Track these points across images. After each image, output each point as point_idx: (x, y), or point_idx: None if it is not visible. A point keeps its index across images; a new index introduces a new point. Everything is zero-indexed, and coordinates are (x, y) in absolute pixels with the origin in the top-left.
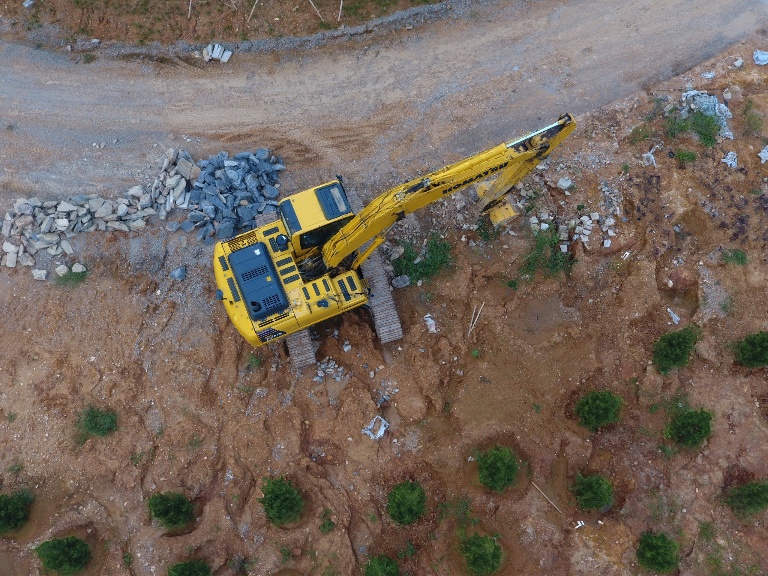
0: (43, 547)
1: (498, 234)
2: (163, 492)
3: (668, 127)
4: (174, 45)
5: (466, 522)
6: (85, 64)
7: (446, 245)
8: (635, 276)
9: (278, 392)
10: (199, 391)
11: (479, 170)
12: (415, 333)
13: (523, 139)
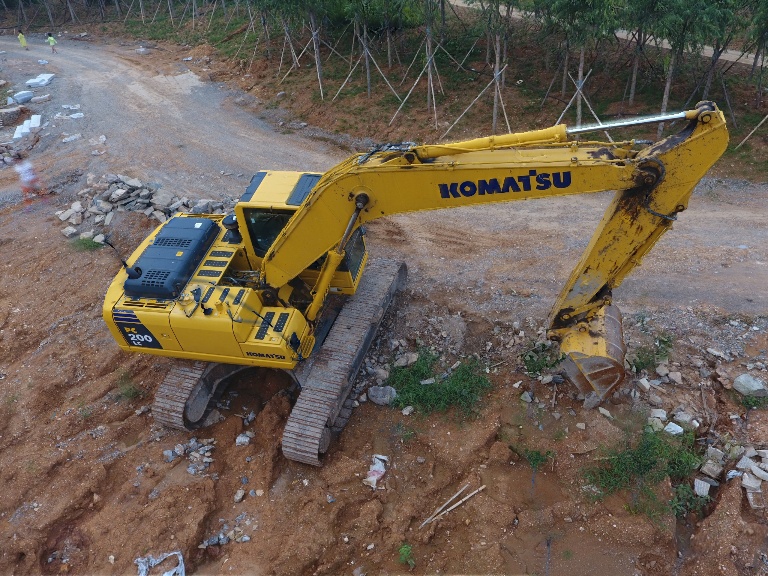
0: None
1: (580, 404)
2: None
3: None
4: (361, 139)
5: None
6: (281, 134)
7: (482, 379)
8: None
9: (113, 440)
10: (46, 387)
11: (507, 160)
12: (342, 469)
13: None
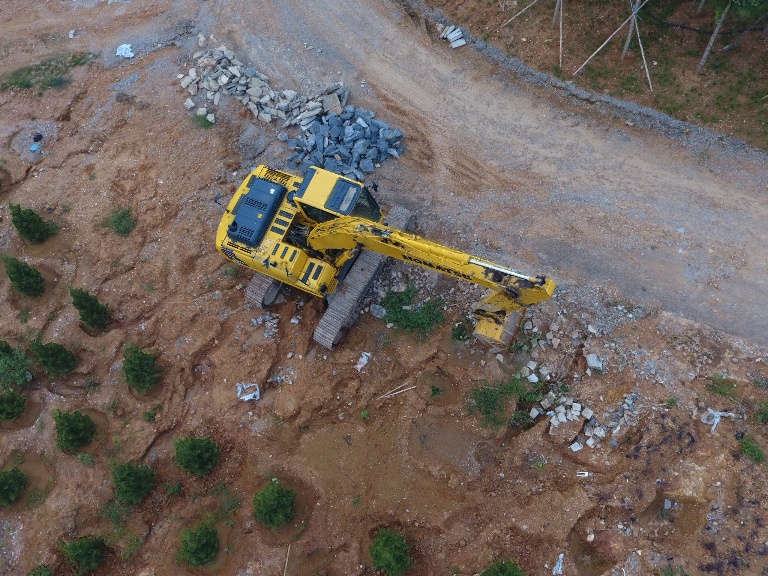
0: (9, 259)
1: None
2: (108, 298)
3: None
4: (432, 9)
5: (222, 515)
6: None
7: (439, 316)
8: (563, 496)
9: (224, 305)
10: (185, 257)
11: (437, 261)
12: (345, 356)
13: (489, 266)
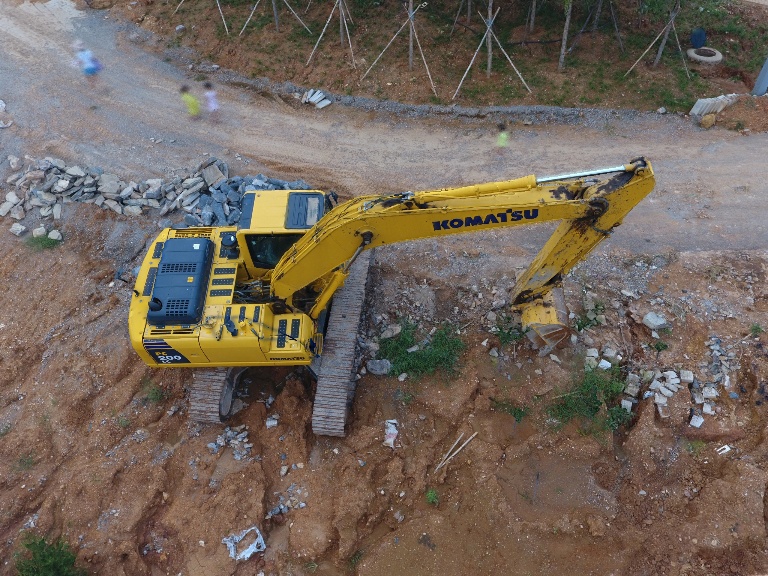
0: None
1: (535, 353)
2: None
3: None
4: (281, 84)
5: None
6: (195, 81)
7: (457, 342)
8: (728, 481)
9: (157, 442)
10: (73, 402)
11: (489, 204)
12: (364, 437)
13: (565, 176)
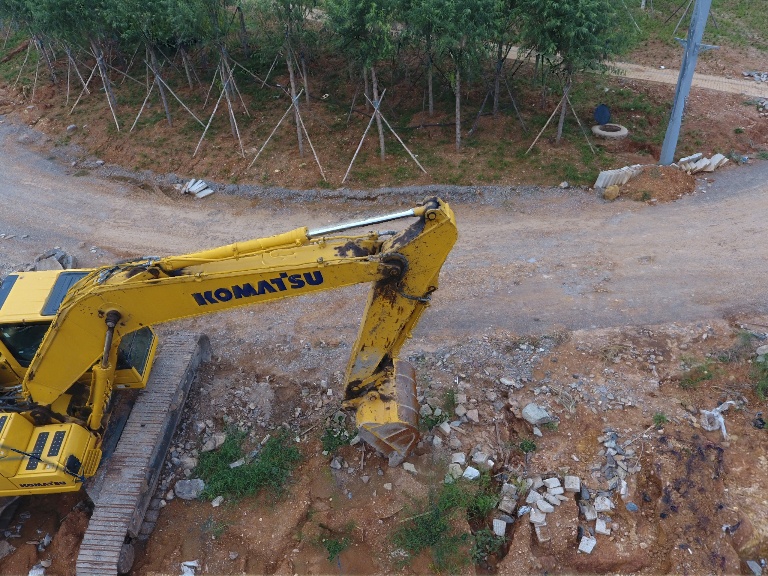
0: None
1: (387, 462)
2: None
3: (761, 380)
4: (164, 176)
5: None
6: (73, 177)
7: (292, 452)
8: None
9: None
10: None
11: (254, 267)
12: None
13: None
